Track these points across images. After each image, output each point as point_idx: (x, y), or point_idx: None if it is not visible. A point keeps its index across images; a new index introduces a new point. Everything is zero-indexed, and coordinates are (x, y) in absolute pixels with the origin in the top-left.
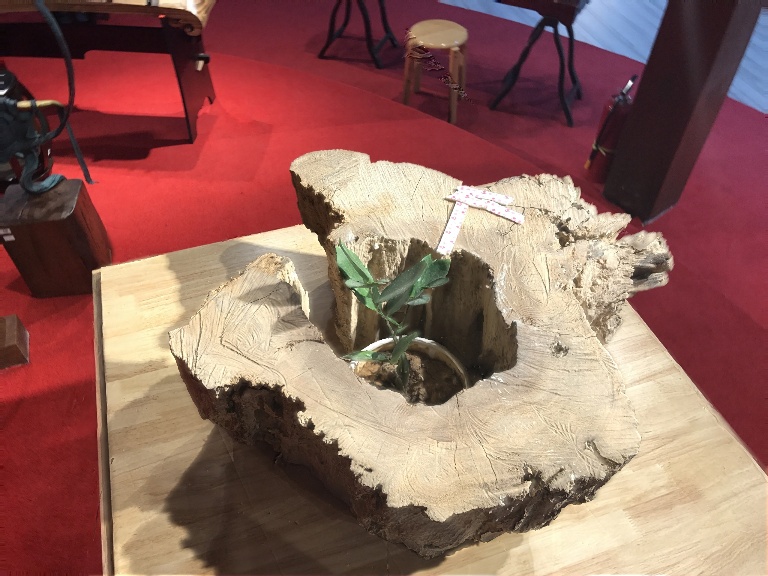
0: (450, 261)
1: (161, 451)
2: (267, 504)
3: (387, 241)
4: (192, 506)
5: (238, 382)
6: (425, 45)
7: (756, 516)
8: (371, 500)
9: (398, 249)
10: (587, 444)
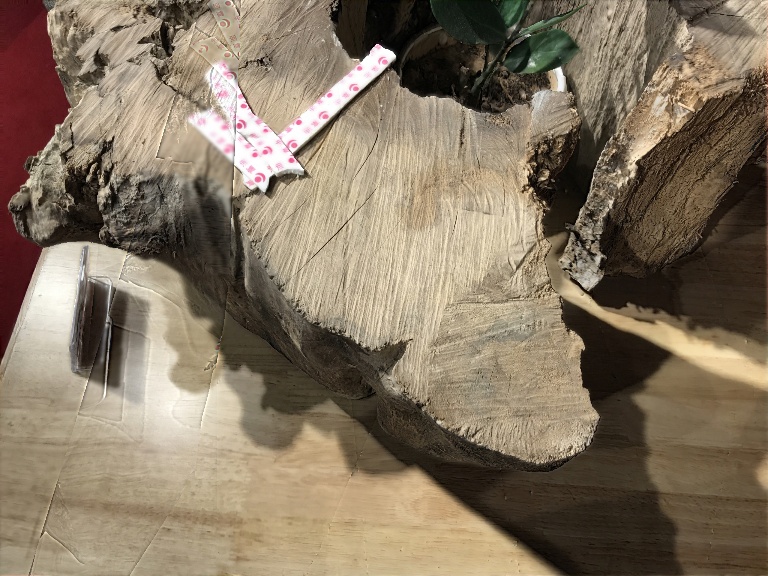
0: None
1: None
2: None
3: None
4: None
5: None
6: (92, 400)
7: None
8: None
9: None
10: None
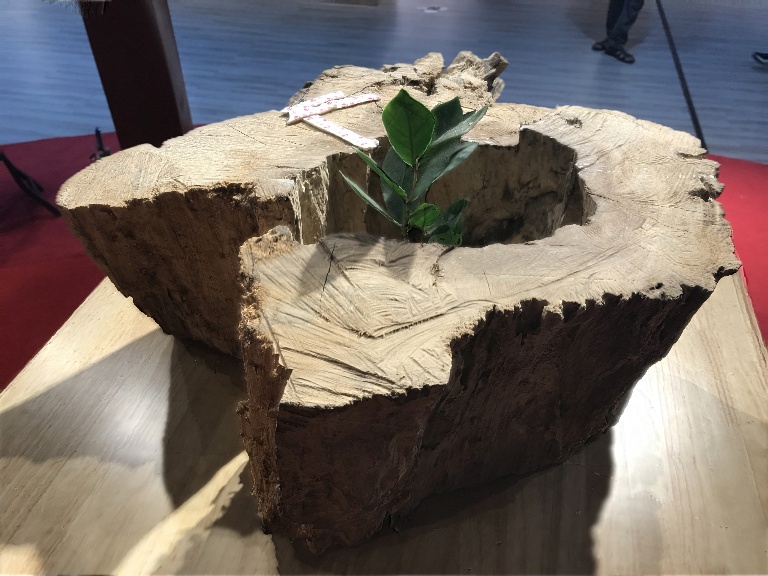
0: None
1: None
2: (454, 567)
3: (309, 174)
4: None
5: None
6: None
7: None
8: (658, 333)
9: (322, 178)
10: None
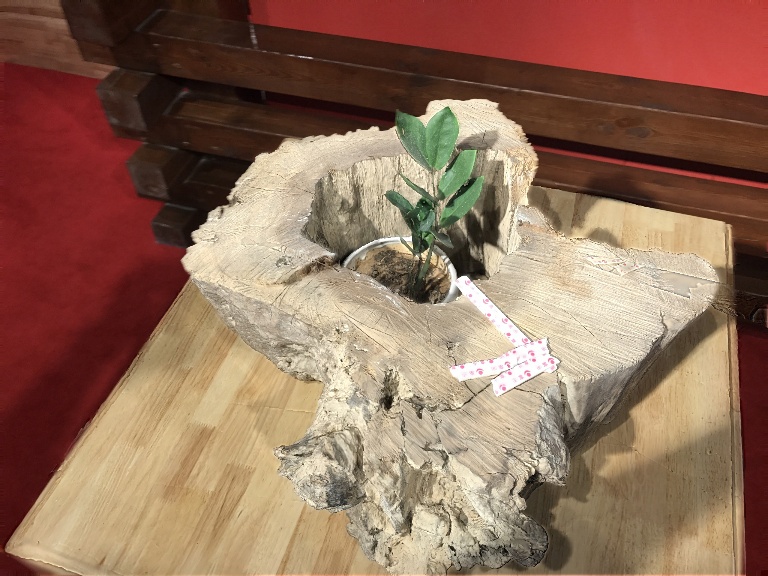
0: None
1: None
2: None
3: None
4: None
5: None
6: None
7: (111, 524)
8: None
9: None
10: None
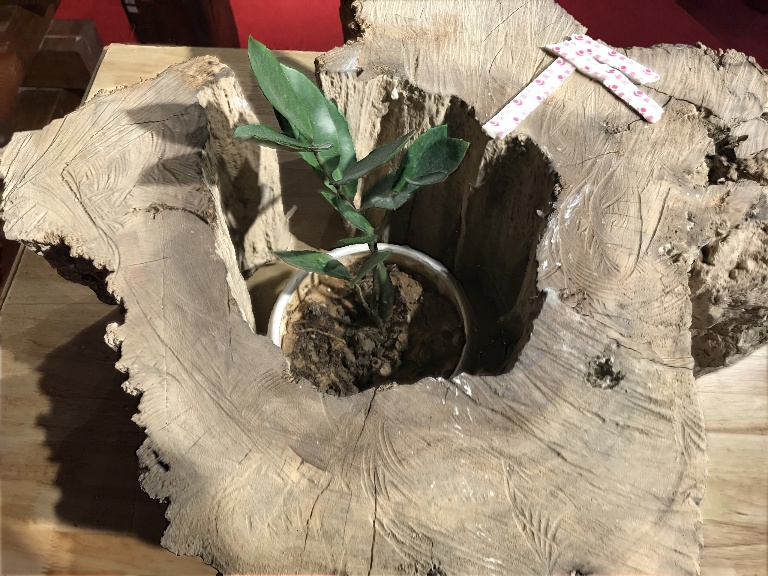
0: (467, 146)
1: (71, 292)
2: None
3: (412, 90)
4: (73, 375)
5: (59, 242)
6: None
7: None
8: None
9: (427, 108)
10: (575, 574)
